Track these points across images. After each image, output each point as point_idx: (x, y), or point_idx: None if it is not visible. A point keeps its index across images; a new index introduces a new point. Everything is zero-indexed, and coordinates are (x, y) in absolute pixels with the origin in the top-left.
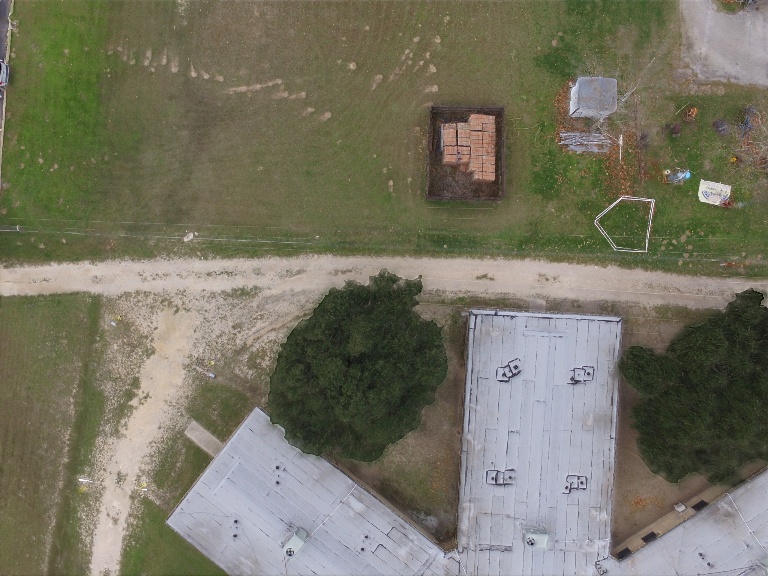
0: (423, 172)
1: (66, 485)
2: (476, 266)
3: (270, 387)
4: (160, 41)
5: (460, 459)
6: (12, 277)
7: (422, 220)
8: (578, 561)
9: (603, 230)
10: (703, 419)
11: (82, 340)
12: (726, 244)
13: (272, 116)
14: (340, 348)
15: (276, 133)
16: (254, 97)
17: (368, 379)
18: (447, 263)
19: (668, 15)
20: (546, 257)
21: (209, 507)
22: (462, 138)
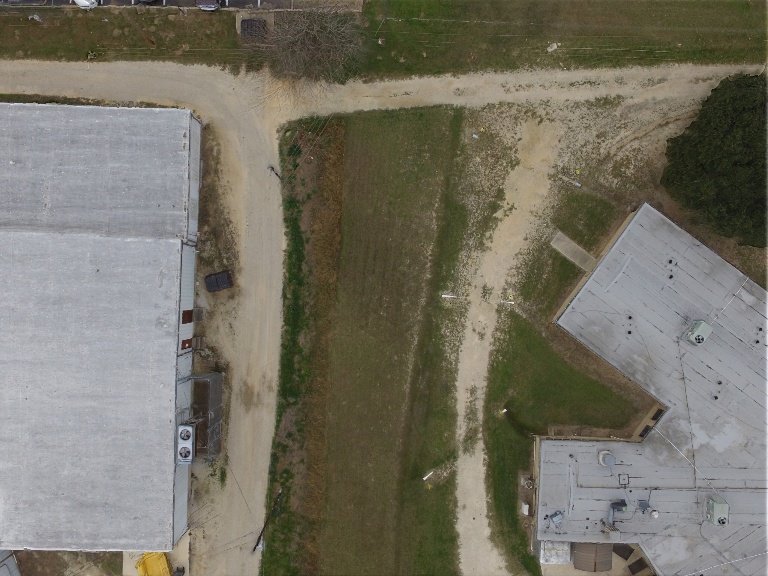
0: None
1: (428, 302)
2: None
3: (675, 173)
4: None
5: None
6: (372, 91)
7: None
8: None
9: None
10: None
11: (444, 153)
12: None
13: None
14: None
15: None
16: None
17: None
18: None
19: None
20: None
21: (601, 305)
22: None
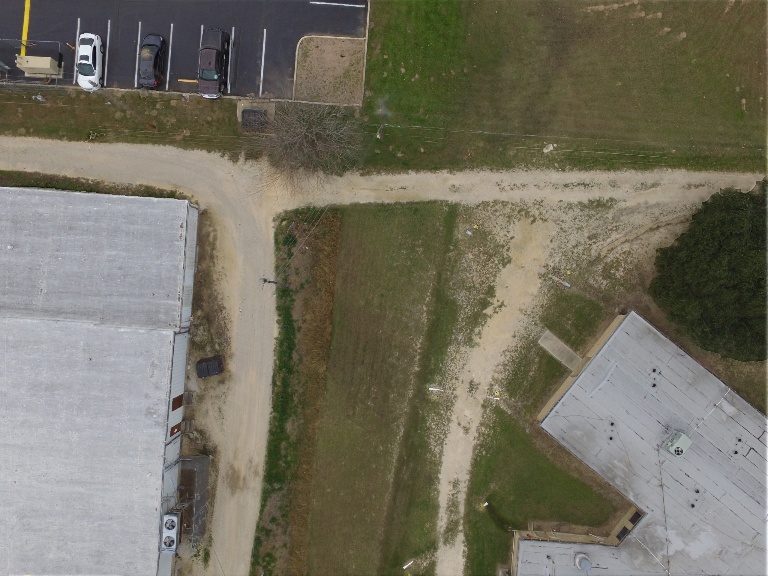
0: None
1: (415, 394)
2: None
3: (662, 287)
4: None
5: None
6: (368, 184)
7: None
8: None
9: None
10: None
11: (438, 248)
12: None
13: (629, 34)
14: (758, 242)
15: (634, 50)
16: (611, 16)
17: None
18: None
19: None
20: None
21: (584, 410)
22: None
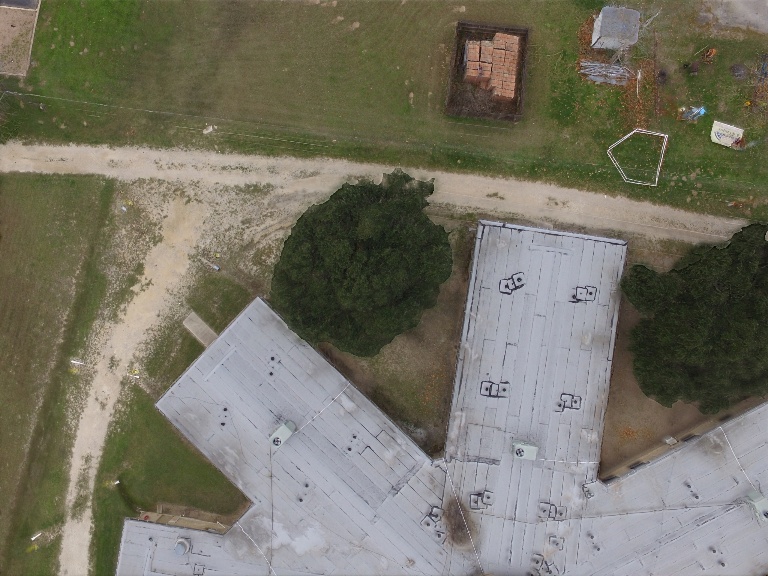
0: (444, 87)
1: (58, 366)
2: (487, 184)
3: (274, 273)
4: None
5: (456, 367)
6: (29, 154)
7: (438, 134)
8: (566, 482)
9: (615, 160)
10: (702, 335)
11: (91, 222)
12: (735, 186)
13: (302, 21)
14: (348, 232)
15: (304, 37)
16: (286, 2)
17: (373, 266)
18: (459, 178)
19: None
20: (557, 182)
21: (200, 393)
22: (485, 54)
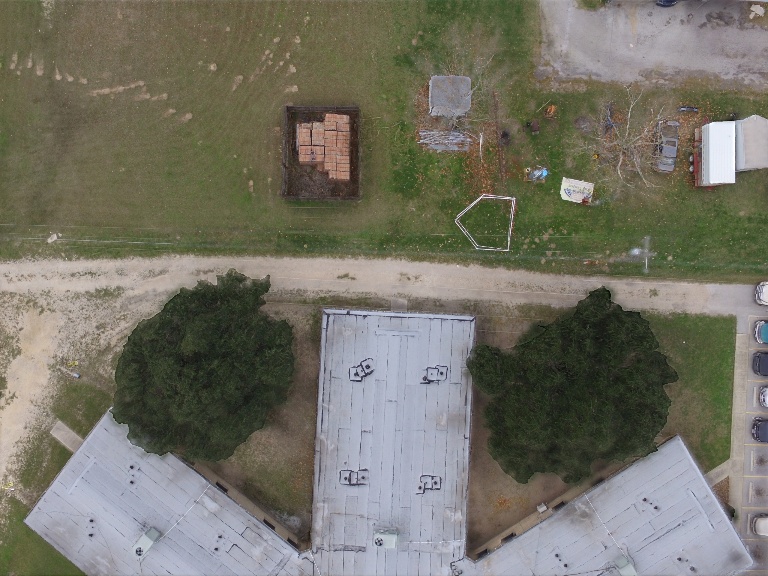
0: None
1: None
2: (337, 266)
3: None
4: (26, 45)
5: (314, 459)
6: None
7: (282, 220)
8: (433, 562)
9: (464, 229)
10: (538, 418)
11: None
12: (590, 242)
13: (134, 118)
14: (176, 348)
15: (138, 134)
16: (117, 99)
17: (204, 378)
18: (308, 263)
19: (528, 13)
20: (407, 256)
21: (65, 506)
22: (316, 138)
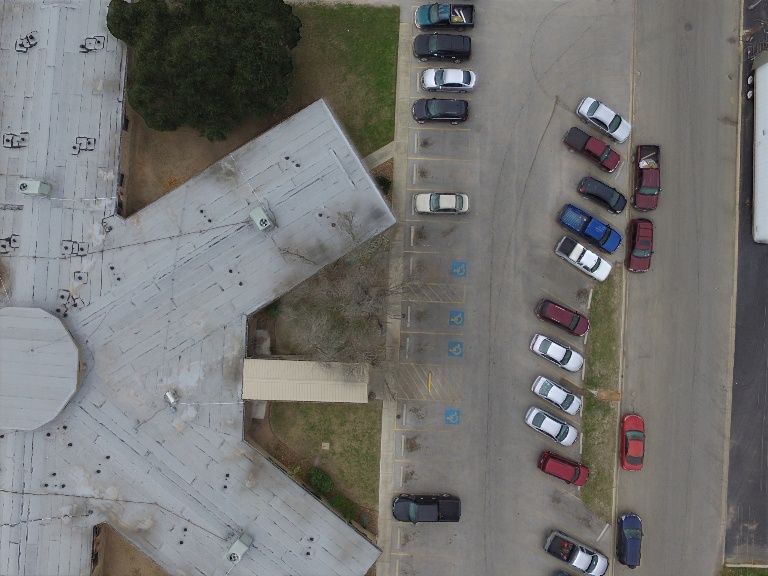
0: None
1: None
2: None
3: None
4: None
5: None
6: None
7: None
8: (86, 219)
9: None
10: (143, 39)
11: None
12: None
13: None
14: None
15: None
16: None
17: None
18: None
19: None
20: None
21: None
22: None
